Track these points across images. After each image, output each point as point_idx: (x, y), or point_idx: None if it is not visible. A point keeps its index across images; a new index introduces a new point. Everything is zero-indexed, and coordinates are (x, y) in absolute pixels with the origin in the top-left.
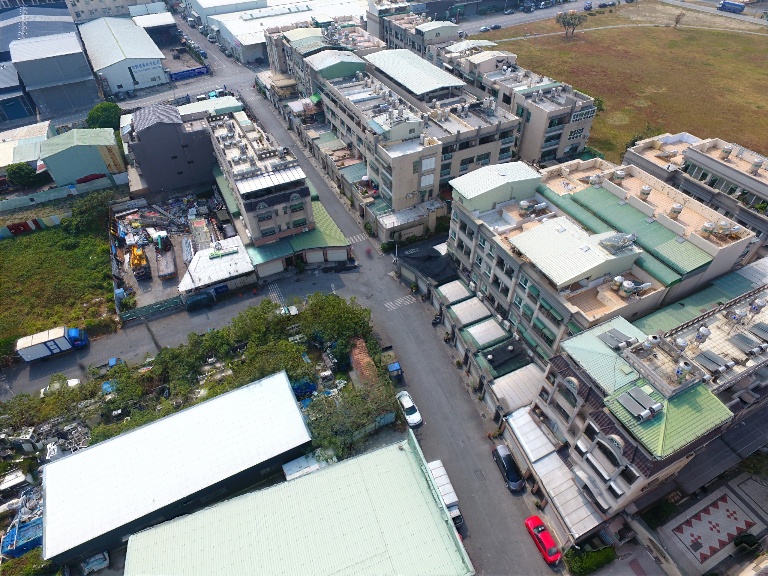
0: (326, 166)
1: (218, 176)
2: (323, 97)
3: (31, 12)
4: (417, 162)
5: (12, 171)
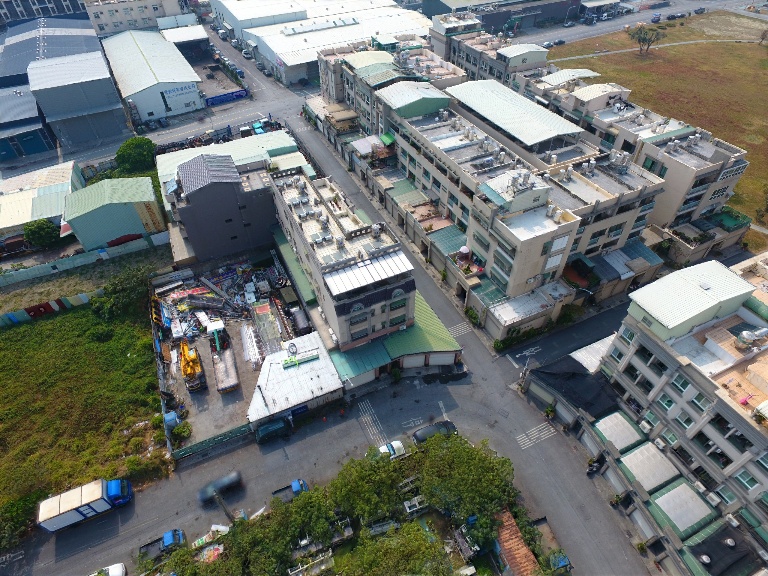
0: (405, 225)
1: (282, 244)
2: (398, 139)
3: (50, 24)
4: (549, 243)
5: (31, 231)
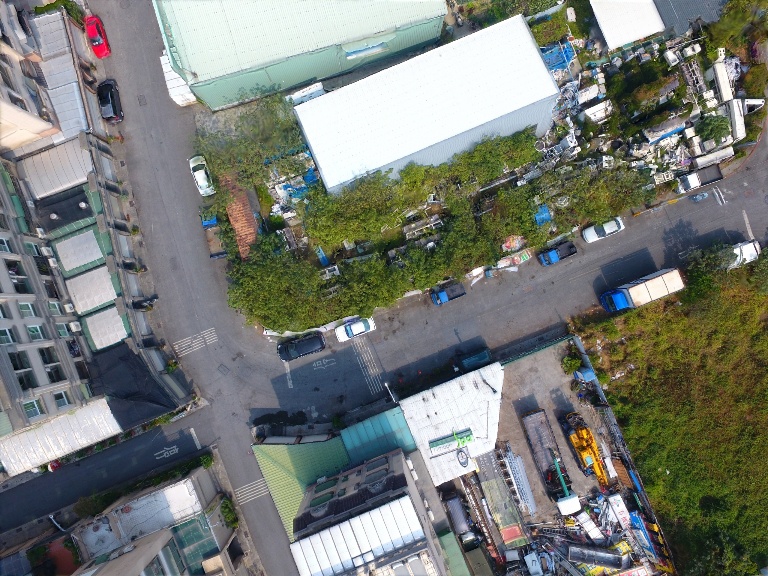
0: None
1: None
2: None
3: None
4: None
5: None
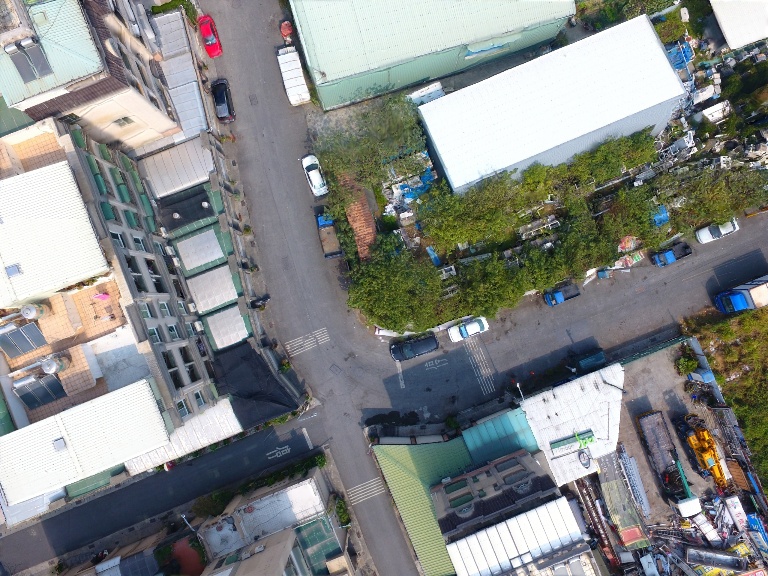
0: None
1: None
2: None
3: None
4: None
5: None
